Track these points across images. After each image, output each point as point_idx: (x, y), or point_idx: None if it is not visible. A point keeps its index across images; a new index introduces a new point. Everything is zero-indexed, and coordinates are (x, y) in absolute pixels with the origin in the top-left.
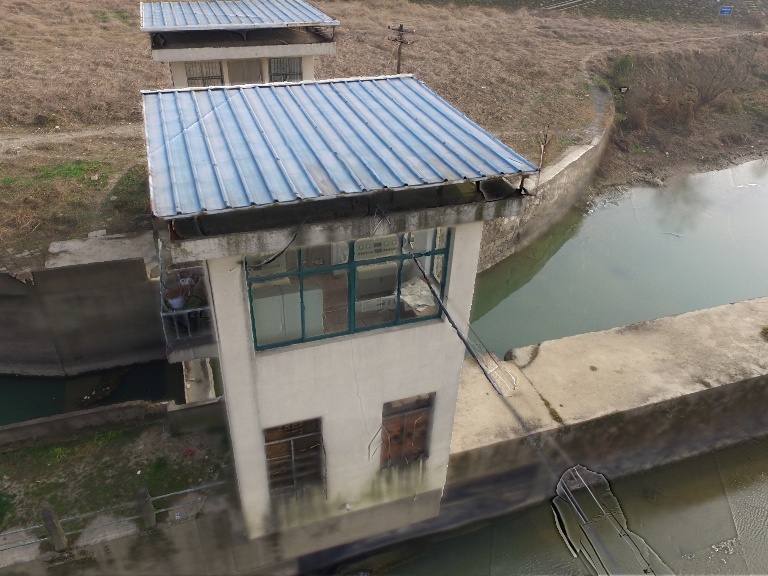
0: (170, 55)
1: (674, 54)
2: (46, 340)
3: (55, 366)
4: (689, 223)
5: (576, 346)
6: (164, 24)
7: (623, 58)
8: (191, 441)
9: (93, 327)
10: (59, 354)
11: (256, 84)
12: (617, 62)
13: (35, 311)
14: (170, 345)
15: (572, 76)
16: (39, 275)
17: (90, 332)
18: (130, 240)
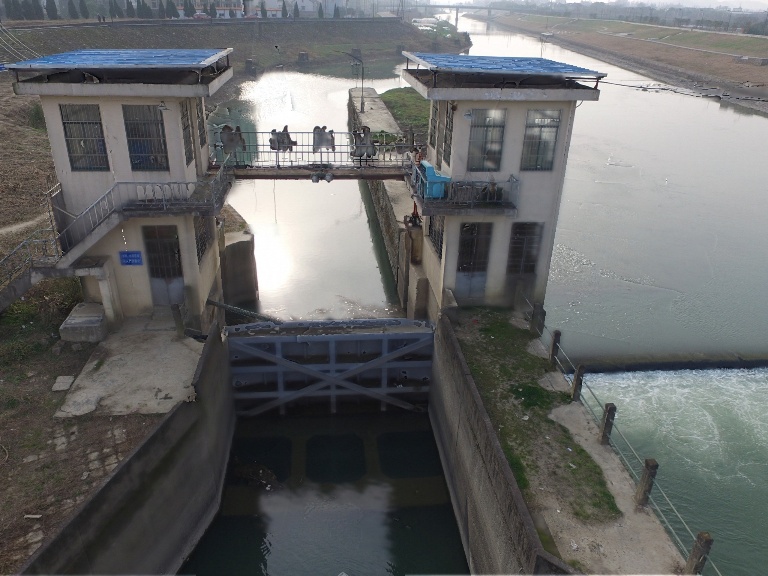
0: (211, 89)
1: (39, 102)
2: (209, 470)
3: (214, 503)
4: (233, 192)
5: (405, 214)
6: (189, 62)
7: (34, 109)
8: (465, 321)
9: (219, 425)
10: (215, 482)
11: (419, 60)
12: (32, 113)
13: (203, 435)
14: (516, 205)
15: (22, 131)
16: (200, 383)
17: (219, 433)
18: (115, 356)
